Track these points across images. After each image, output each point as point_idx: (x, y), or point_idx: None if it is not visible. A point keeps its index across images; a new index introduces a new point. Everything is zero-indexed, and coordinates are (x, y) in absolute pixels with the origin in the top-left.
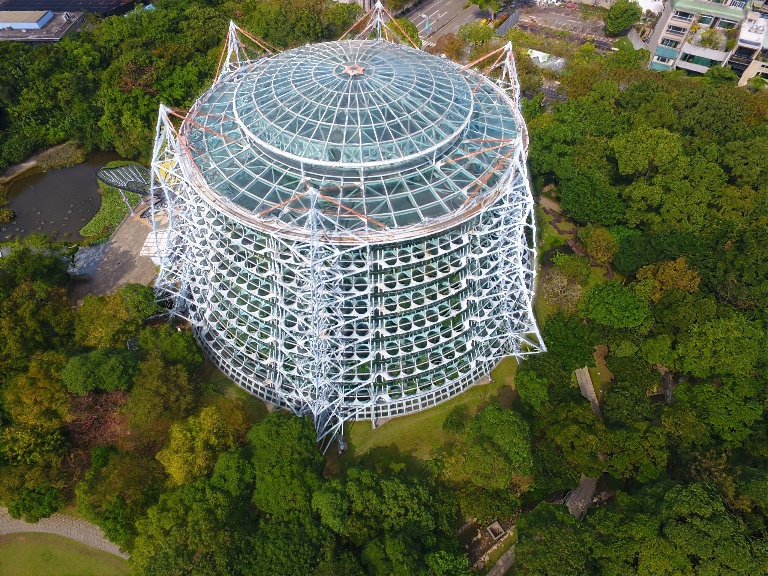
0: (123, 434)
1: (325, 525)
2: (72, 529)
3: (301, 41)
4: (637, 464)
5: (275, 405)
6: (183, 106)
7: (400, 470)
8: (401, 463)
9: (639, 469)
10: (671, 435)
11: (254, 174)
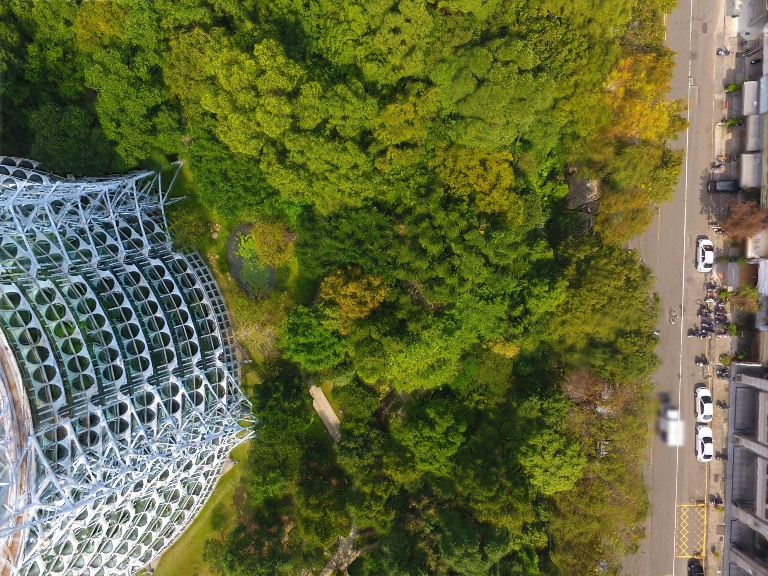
0: None
1: None
2: None
3: None
4: None
5: None
6: None
7: None
8: None
9: None
10: None
11: None
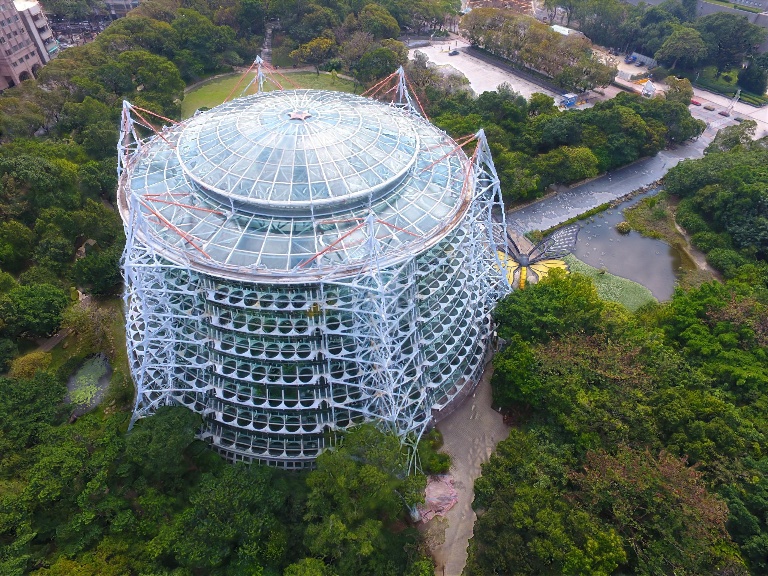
0: None
1: None
2: None
3: None
4: None
5: None
6: (676, 344)
7: None
8: None
9: None
10: None
11: None
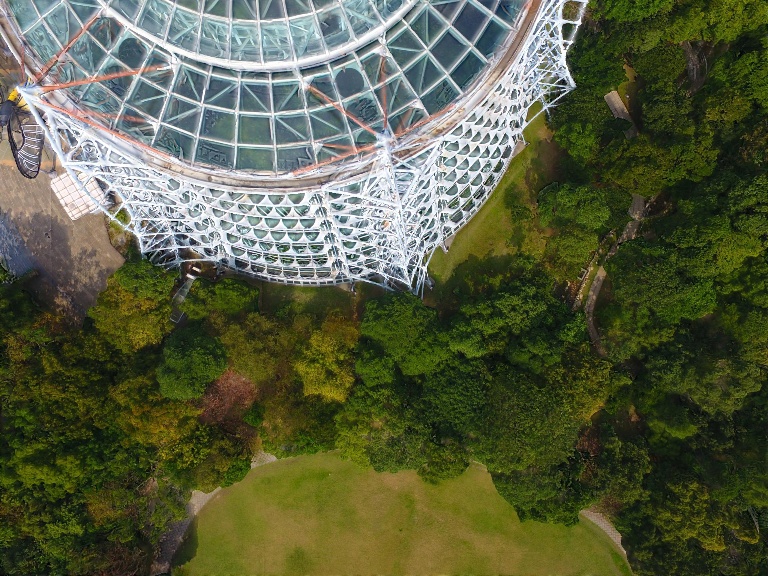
0: (239, 383)
1: (471, 358)
2: (266, 457)
3: None
4: (691, 168)
5: (348, 283)
6: None
7: (500, 282)
8: (498, 276)
9: (692, 171)
10: (712, 122)
11: (229, 110)
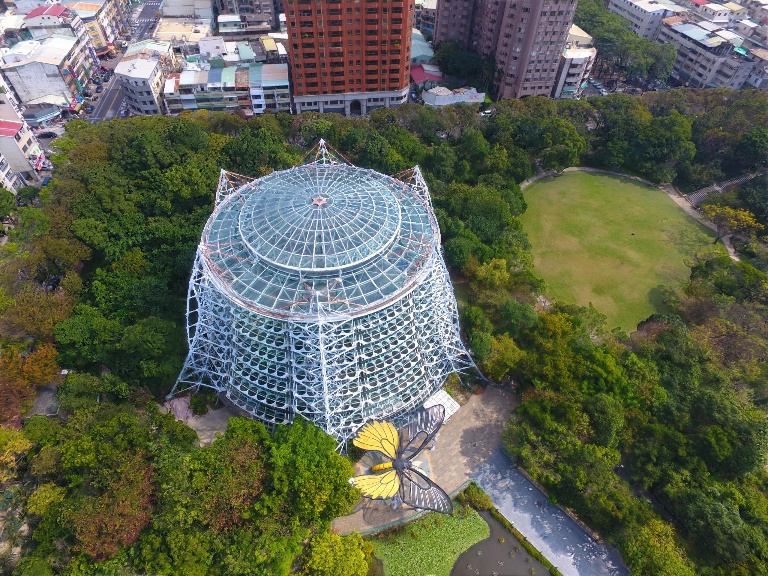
0: None
1: None
2: None
3: (34, 572)
4: None
5: None
6: None
7: None
8: None
9: None
10: None
11: None
